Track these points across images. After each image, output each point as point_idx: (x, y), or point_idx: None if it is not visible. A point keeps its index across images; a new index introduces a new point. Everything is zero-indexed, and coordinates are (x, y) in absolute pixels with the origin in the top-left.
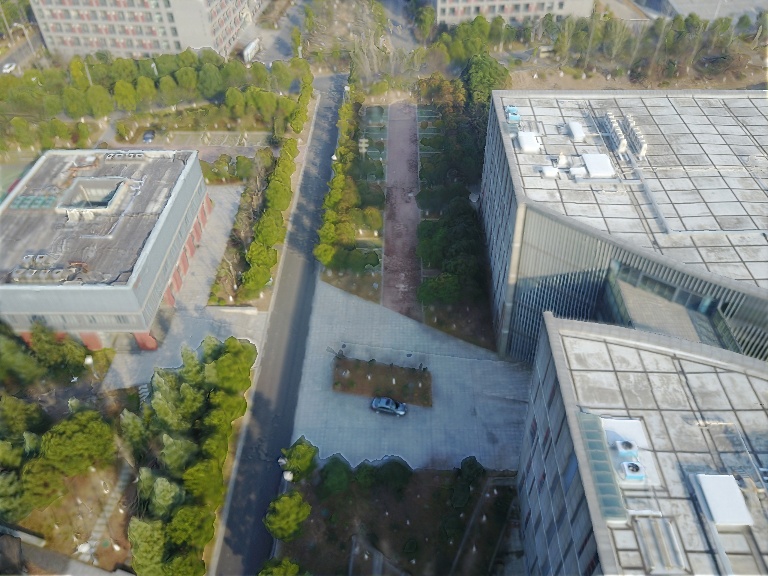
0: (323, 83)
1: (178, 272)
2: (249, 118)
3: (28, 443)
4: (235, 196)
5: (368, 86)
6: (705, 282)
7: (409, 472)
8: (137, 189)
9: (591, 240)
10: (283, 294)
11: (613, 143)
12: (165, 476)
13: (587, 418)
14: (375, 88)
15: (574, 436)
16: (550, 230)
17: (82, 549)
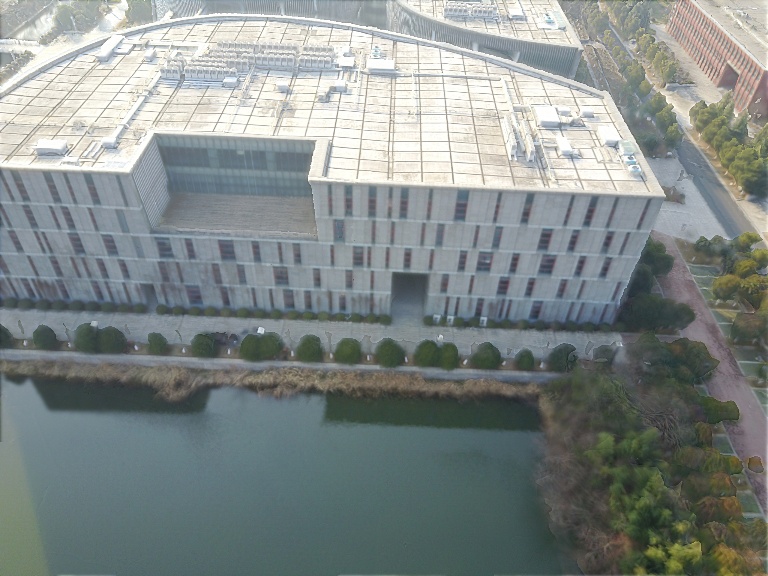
0: None
1: None
2: None
3: None
4: None
5: None
6: None
7: None
8: None
9: None
10: (761, 246)
11: None
12: None
13: None
14: None
15: None
16: None
17: None
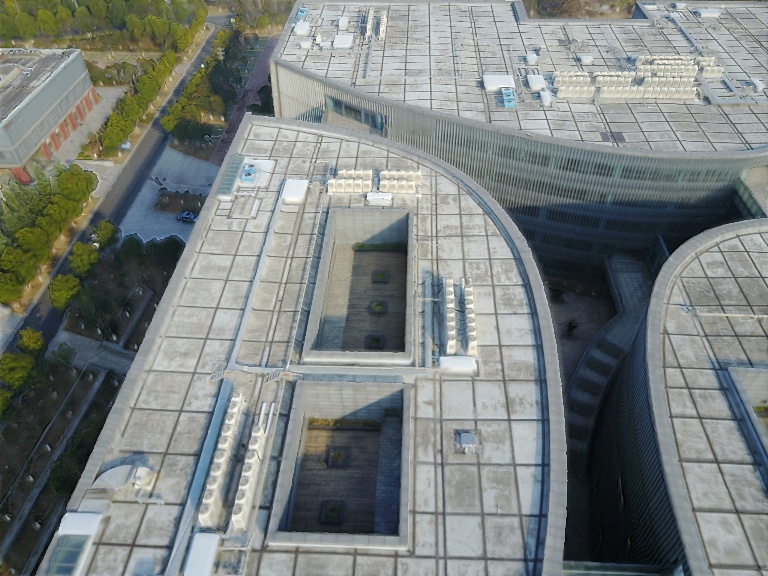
0: (220, 19)
1: (57, 136)
2: (147, 41)
3: None
4: (121, 94)
5: (254, 20)
6: (370, 101)
7: (183, 246)
8: (28, 73)
9: (311, 82)
10: (137, 155)
11: (366, 30)
12: (5, 235)
13: (237, 156)
14: (258, 21)
15: (223, 164)
16: (291, 79)
17: None
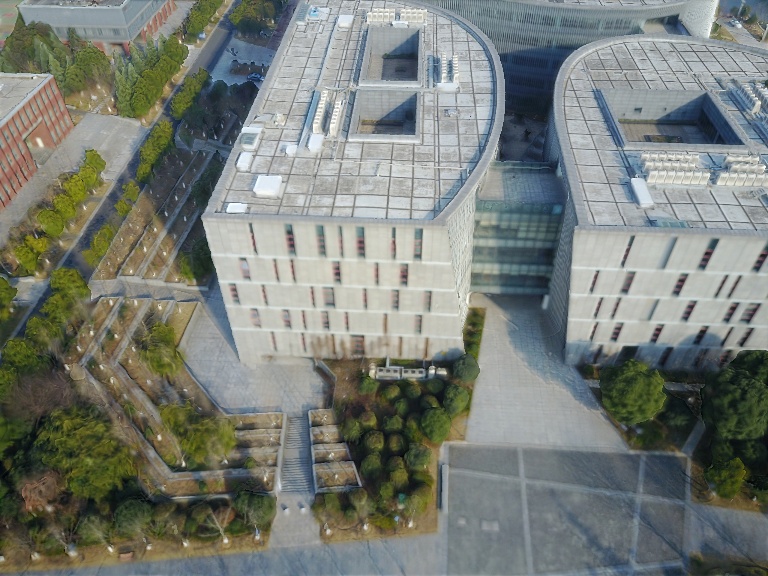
0: None
1: None
2: None
3: (68, 62)
4: (191, 5)
5: None
6: None
7: (257, 89)
8: None
9: None
10: (211, 42)
11: None
12: None
13: (305, 4)
14: None
15: (297, 7)
16: None
17: (93, 97)
